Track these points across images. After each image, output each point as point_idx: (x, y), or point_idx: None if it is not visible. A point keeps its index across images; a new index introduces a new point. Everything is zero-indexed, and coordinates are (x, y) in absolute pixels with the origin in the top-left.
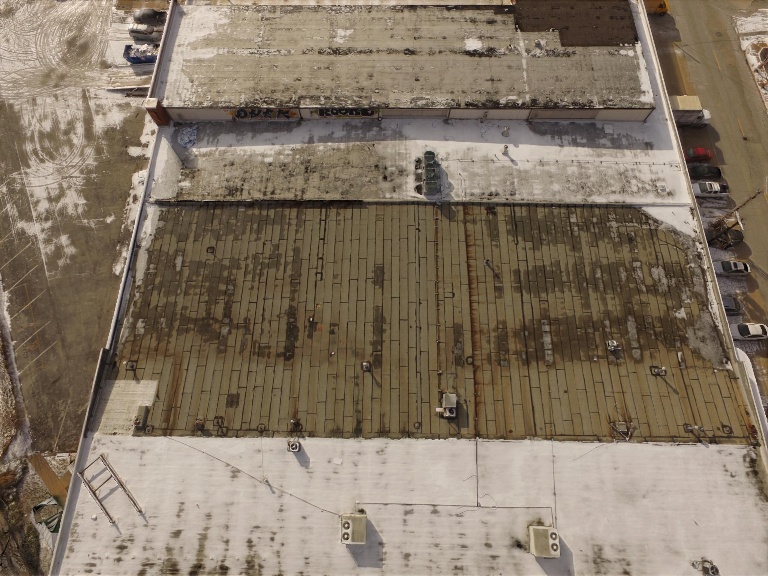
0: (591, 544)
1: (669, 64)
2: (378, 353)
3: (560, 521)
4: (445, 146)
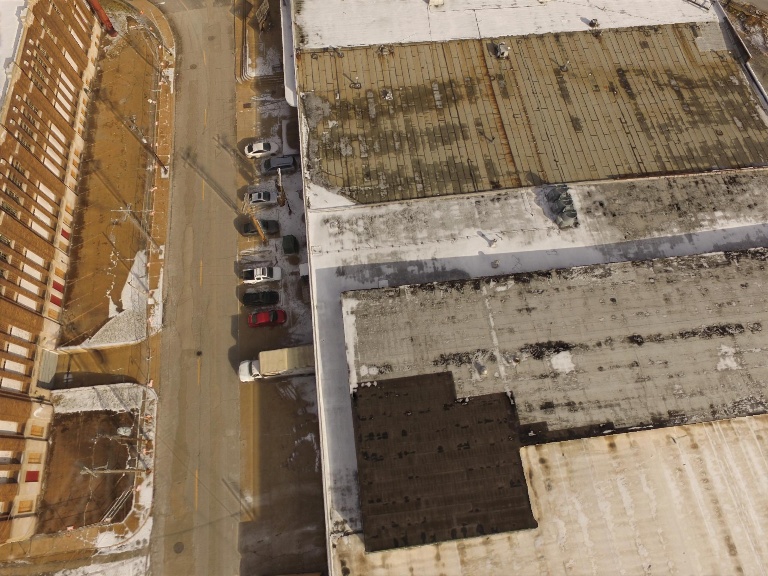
0: (407, 1)
1: (266, 470)
2: (559, 76)
3: (425, 8)
4: (554, 243)
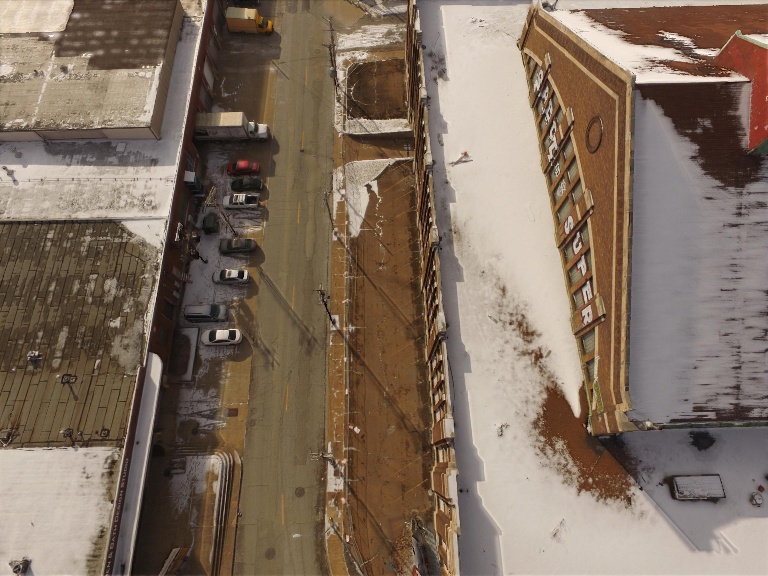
0: None
1: (259, 81)
2: None
3: None
4: None
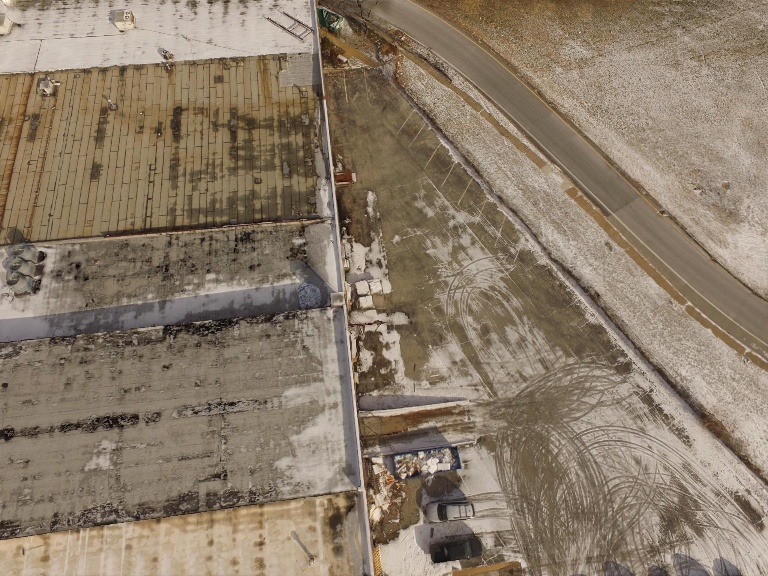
0: None
1: None
2: (103, 116)
3: None
4: (0, 313)
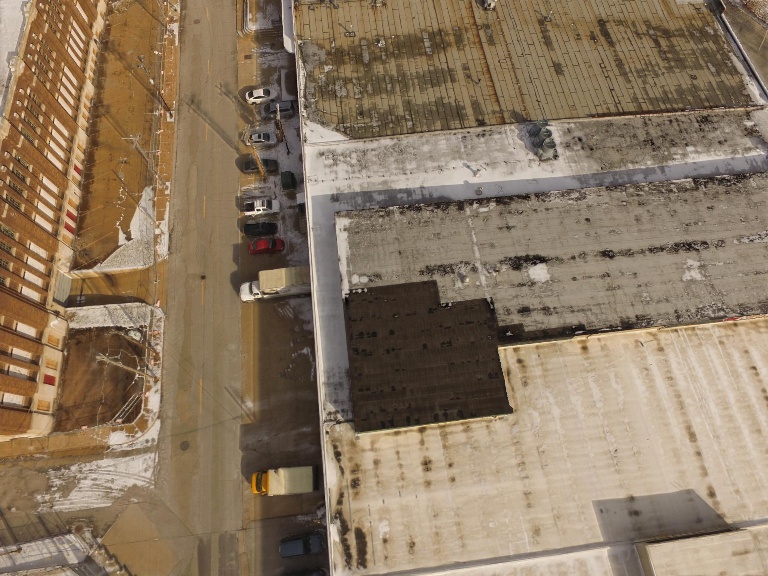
0: None
1: (266, 380)
2: (543, 26)
3: None
4: (535, 173)
